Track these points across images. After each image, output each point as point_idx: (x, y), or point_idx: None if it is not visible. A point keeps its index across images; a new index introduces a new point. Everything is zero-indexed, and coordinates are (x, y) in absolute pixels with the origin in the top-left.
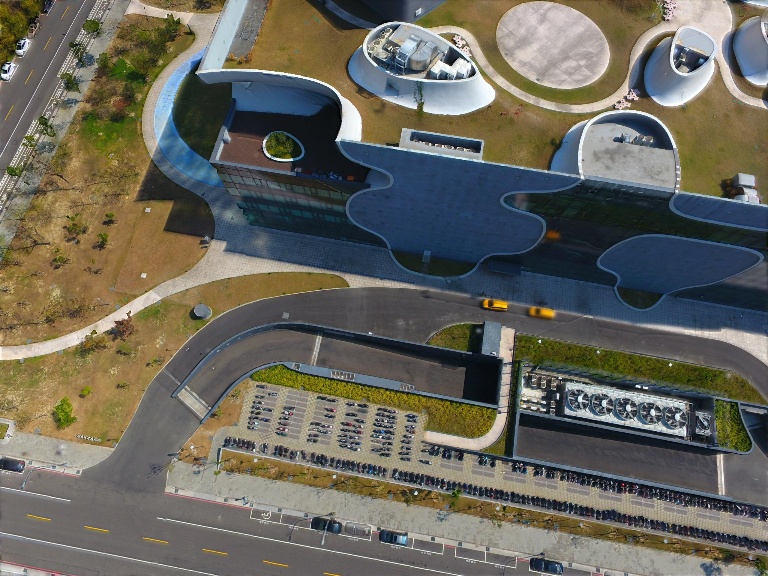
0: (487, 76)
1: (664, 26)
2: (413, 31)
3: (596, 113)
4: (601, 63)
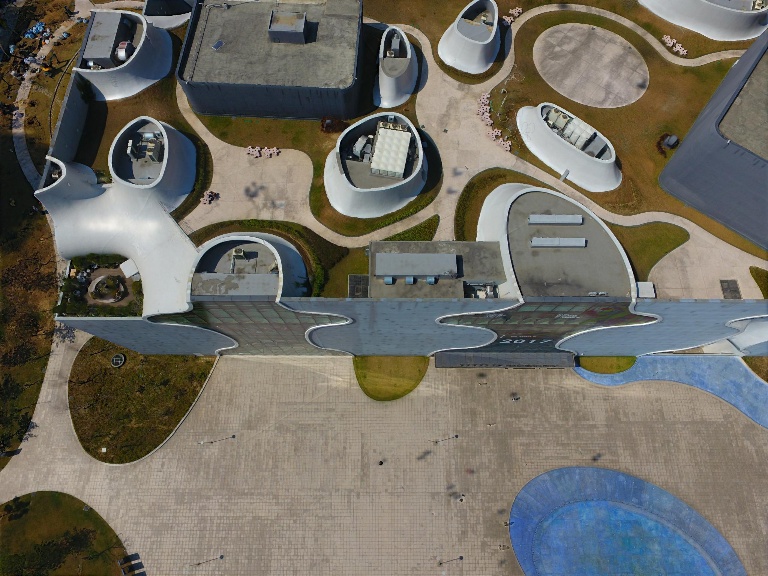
0: (640, 25)
1: (487, 88)
2: (737, 7)
3: (537, 4)
4: (540, 50)
